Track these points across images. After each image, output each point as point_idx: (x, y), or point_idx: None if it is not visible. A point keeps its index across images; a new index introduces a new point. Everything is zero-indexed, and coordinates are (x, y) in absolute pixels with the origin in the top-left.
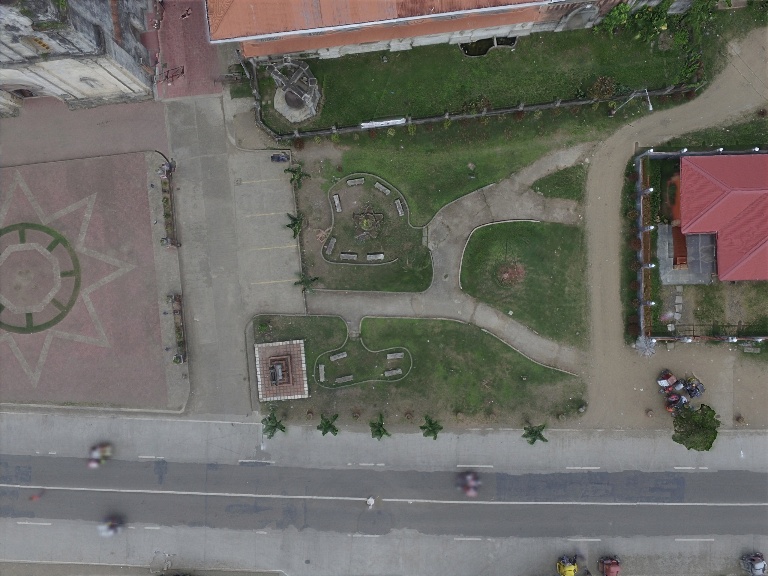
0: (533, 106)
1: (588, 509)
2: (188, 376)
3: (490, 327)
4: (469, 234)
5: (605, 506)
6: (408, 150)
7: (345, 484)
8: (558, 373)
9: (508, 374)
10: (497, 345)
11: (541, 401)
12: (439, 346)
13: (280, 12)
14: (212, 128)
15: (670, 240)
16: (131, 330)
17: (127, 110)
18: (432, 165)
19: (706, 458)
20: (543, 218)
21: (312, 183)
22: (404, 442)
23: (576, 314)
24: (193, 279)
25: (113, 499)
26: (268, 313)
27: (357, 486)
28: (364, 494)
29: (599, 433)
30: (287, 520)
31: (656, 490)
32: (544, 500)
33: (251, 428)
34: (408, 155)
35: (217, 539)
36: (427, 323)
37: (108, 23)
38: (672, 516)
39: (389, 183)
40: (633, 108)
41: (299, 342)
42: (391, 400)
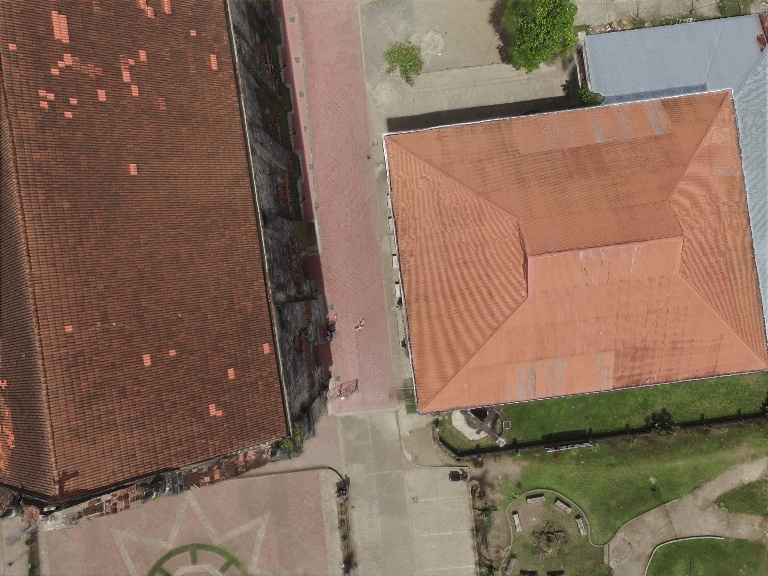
0: (720, 424)
1: None
2: None
3: None
4: (652, 552)
5: None
6: (588, 464)
7: None
8: None
9: None
10: None
11: None
12: None
13: (493, 389)
14: (387, 444)
15: None
16: None
17: None
18: (613, 480)
19: None
20: (727, 534)
21: (490, 500)
22: None
23: None
24: None
25: None
26: None
27: None
28: None
29: None
30: None
31: None
32: None
33: None
34: (588, 470)
35: None
36: None
37: (306, 383)
38: None
39: (569, 499)
40: None
41: None
42: None
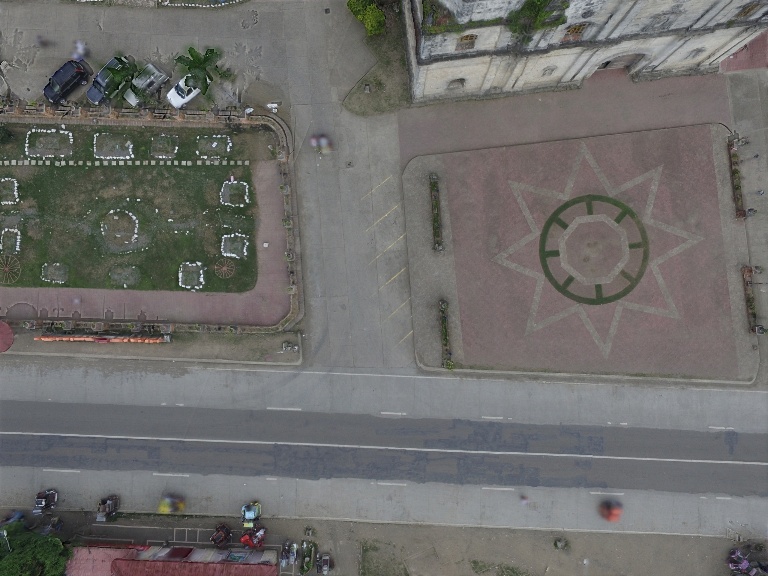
0: None
1: None
2: (758, 347)
3: None
4: None
5: None
6: None
7: None
8: None
9: None
10: None
11: None
12: None
13: None
14: None
15: None
16: (701, 301)
17: (690, 82)
18: None
19: None
20: None
21: None
22: None
23: None
24: (759, 251)
25: (685, 469)
26: None
27: None
28: None
29: None
30: None
31: None
32: None
33: None
34: None
35: None
36: None
37: None
38: None
39: None
40: None
41: None
42: None
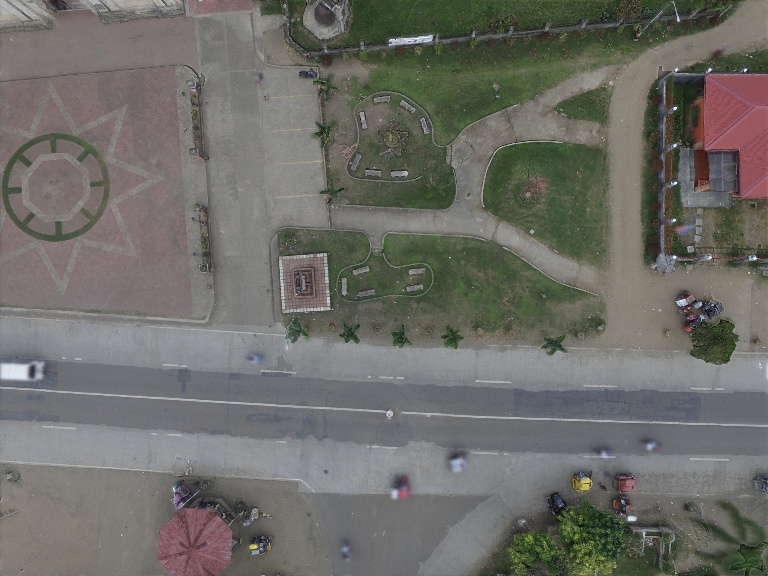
0: (559, 27)
1: (604, 427)
2: (213, 286)
3: (511, 245)
4: (492, 153)
5: (621, 424)
6: (434, 70)
7: (365, 396)
8: (577, 292)
9: (528, 292)
10: (518, 263)
11: (560, 319)
12: (460, 263)
13: None
14: (241, 44)
15: (691, 163)
16: (158, 240)
17: (158, 25)
18: (457, 85)
19: (722, 379)
20: (566, 139)
21: (339, 100)
22: (424, 356)
23: (597, 234)
24: (220, 192)
25: (137, 405)
26: (293, 226)
27: (377, 398)
28: (383, 406)
29: (617, 352)
30: (307, 430)
31: (672, 410)
32: (561, 417)
33: (273, 339)
34: (434, 75)
35: (238, 447)
36: (449, 240)
37: None
38: (687, 436)
39: (414, 102)
40: (658, 32)
41: (323, 255)
42: (412, 315)
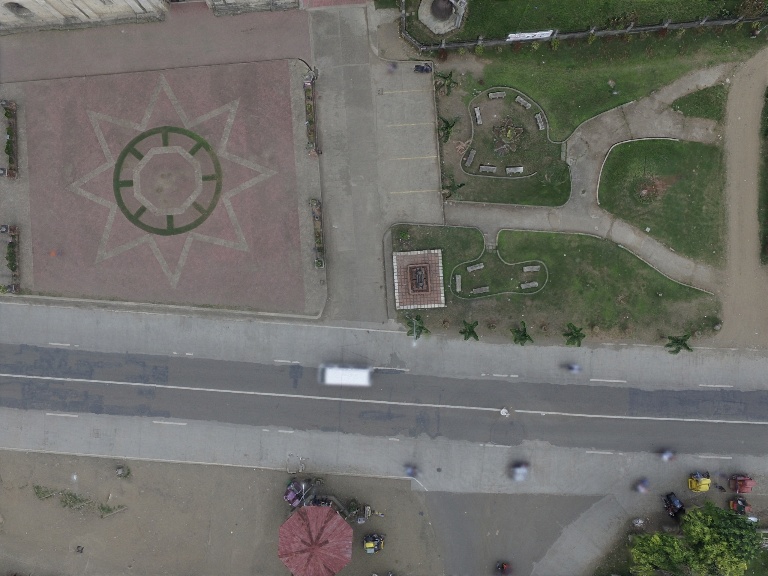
0: (677, 24)
1: (720, 427)
2: (326, 282)
3: (626, 243)
4: (608, 150)
5: (737, 424)
6: (549, 65)
7: (479, 394)
8: (693, 291)
9: (644, 290)
10: (633, 261)
11: (676, 318)
12: (575, 260)
13: None
14: (355, 38)
15: None
16: (271, 235)
17: (271, 18)
18: (572, 81)
19: None
20: (682, 137)
21: (453, 95)
22: (538, 354)
23: (713, 233)
24: (333, 187)
25: (248, 401)
26: (407, 222)
27: (490, 396)
28: (497, 405)
29: (733, 352)
30: (420, 428)
31: None
32: (676, 416)
33: (386, 336)
34: (549, 70)
35: (350, 444)
36: (564, 237)
37: None
38: None
39: (529, 97)
40: None
41: (437, 252)
42: (526, 312)
